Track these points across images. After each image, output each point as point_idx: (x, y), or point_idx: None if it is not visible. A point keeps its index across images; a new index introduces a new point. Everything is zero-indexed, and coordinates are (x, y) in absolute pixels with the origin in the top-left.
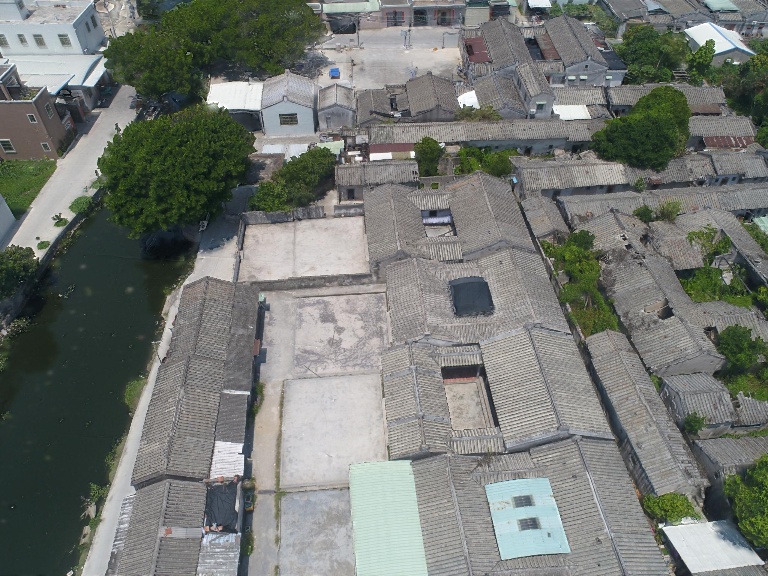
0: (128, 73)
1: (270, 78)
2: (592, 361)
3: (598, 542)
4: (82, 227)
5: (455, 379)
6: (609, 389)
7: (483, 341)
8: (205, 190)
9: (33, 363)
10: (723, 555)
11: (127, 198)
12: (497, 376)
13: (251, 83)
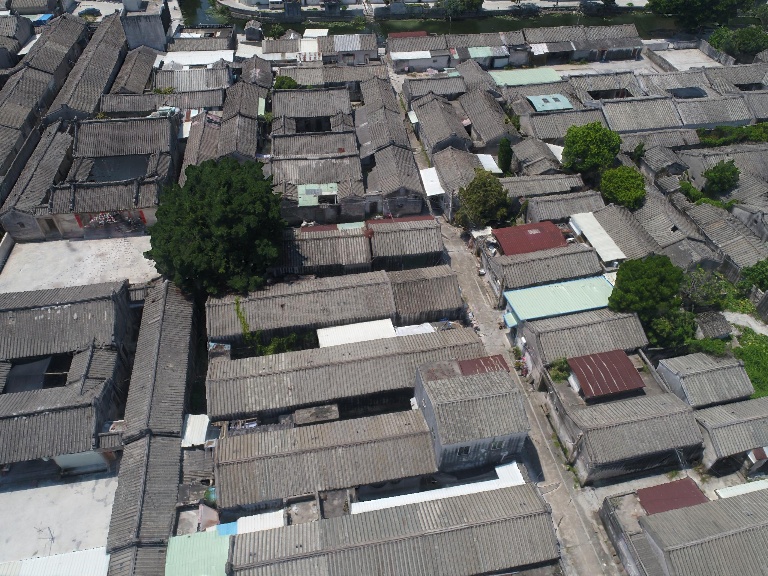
0: None
1: None
2: None
3: None
4: (654, 14)
5: None
6: (647, 131)
7: None
8: None
9: (563, 21)
10: (560, 155)
11: None
12: None
13: None
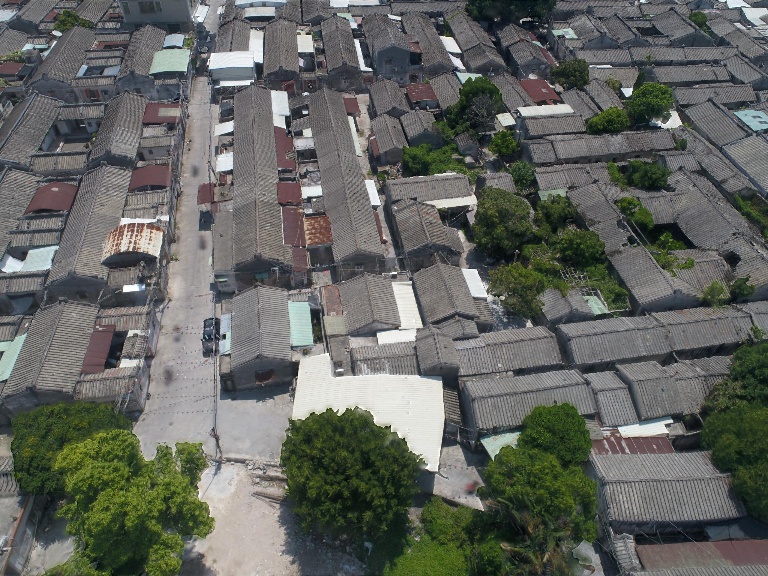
0: None
1: None
2: None
3: None
4: None
5: None
6: None
7: None
8: None
9: None
10: None
11: None
12: None
13: None
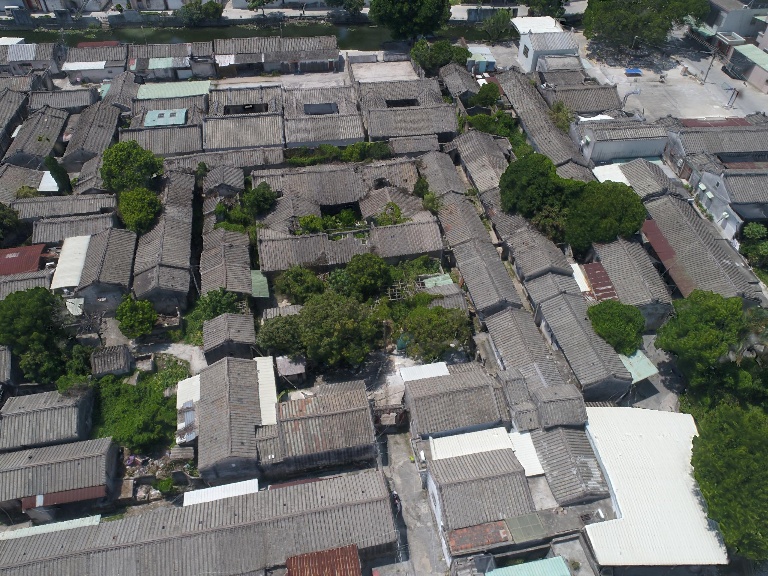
0: None
1: None
2: None
3: None
4: None
5: None
6: None
7: None
8: (382, 7)
9: (303, 31)
10: None
11: None
12: None
13: (558, 27)
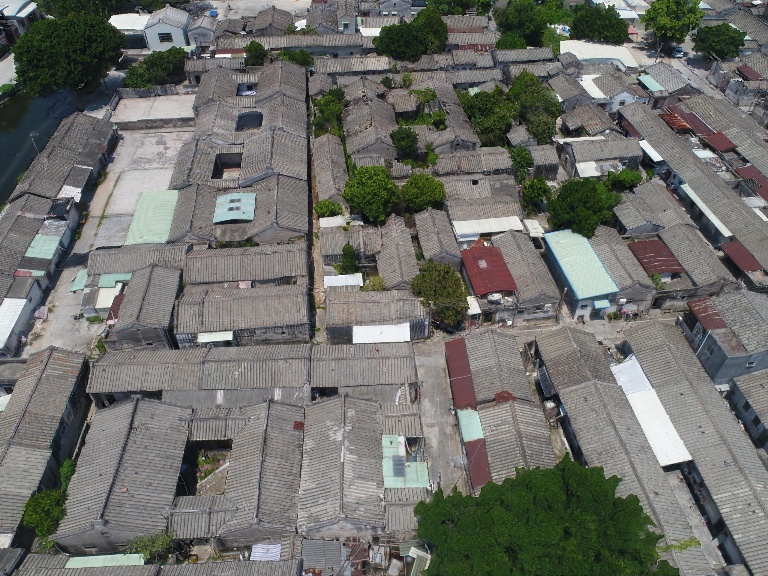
0: (47, 4)
1: (156, 11)
2: (312, 149)
3: (268, 213)
4: (6, 102)
5: (233, 169)
6: (315, 160)
7: (246, 140)
8: (80, 60)
9: None
10: (344, 223)
11: (29, 67)
12: (247, 154)
13: (141, 14)
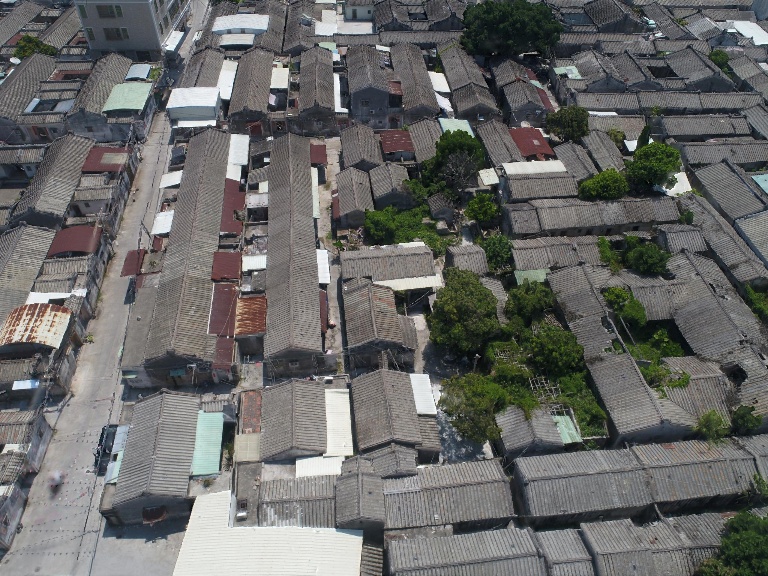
0: None
1: None
2: None
3: None
4: None
5: None
6: None
7: None
8: None
9: None
10: None
11: None
12: None
13: None
